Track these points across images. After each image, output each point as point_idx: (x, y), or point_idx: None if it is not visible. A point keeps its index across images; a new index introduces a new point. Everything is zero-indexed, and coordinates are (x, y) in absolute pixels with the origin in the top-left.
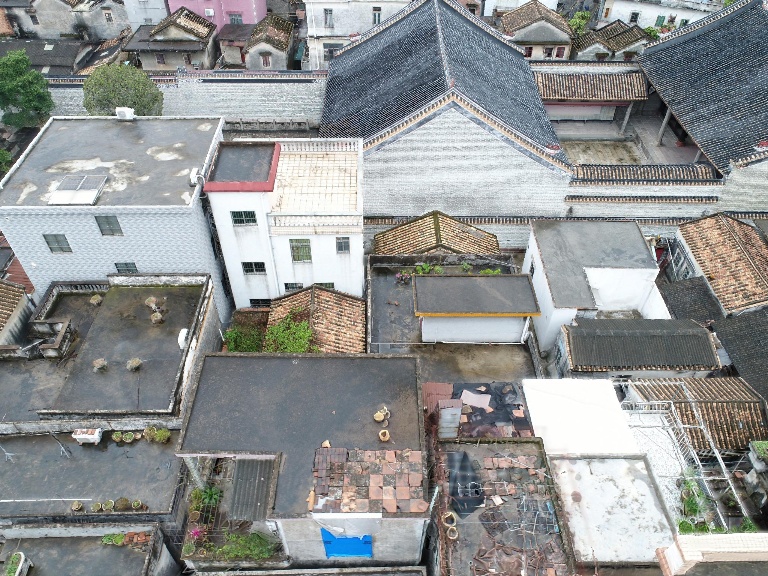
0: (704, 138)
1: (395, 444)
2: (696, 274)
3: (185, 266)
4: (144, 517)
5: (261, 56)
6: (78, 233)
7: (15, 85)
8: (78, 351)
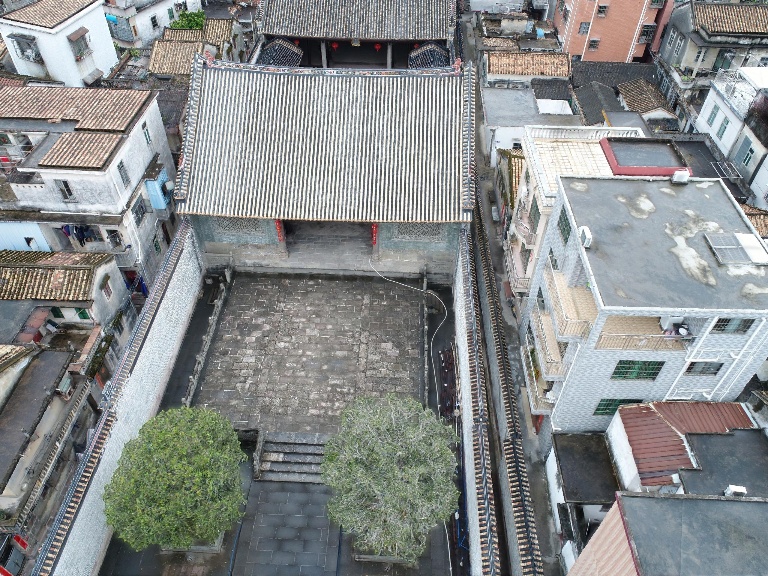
0: (405, 34)
1: None
2: (526, 82)
3: None
4: None
5: (102, 290)
6: None
7: None
8: None
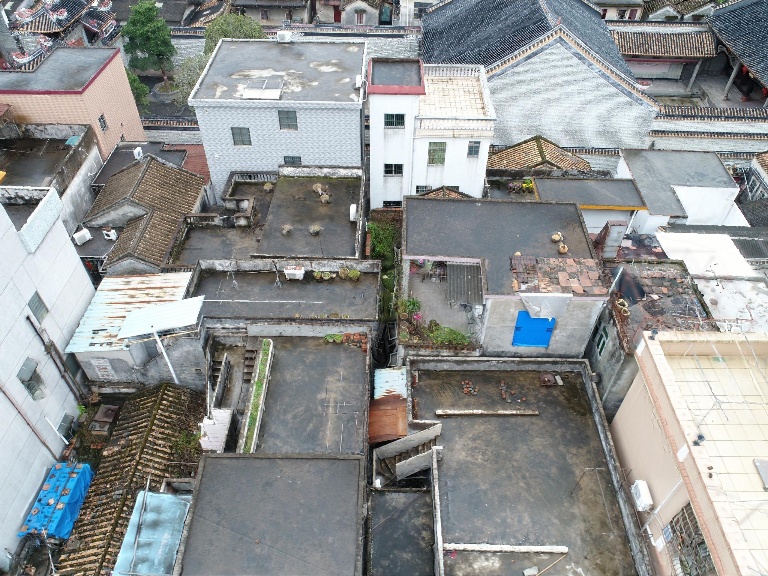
0: None
1: (572, 255)
2: None
3: (342, 161)
4: (356, 323)
5: (356, 13)
6: (261, 127)
7: (146, 30)
8: (261, 223)
